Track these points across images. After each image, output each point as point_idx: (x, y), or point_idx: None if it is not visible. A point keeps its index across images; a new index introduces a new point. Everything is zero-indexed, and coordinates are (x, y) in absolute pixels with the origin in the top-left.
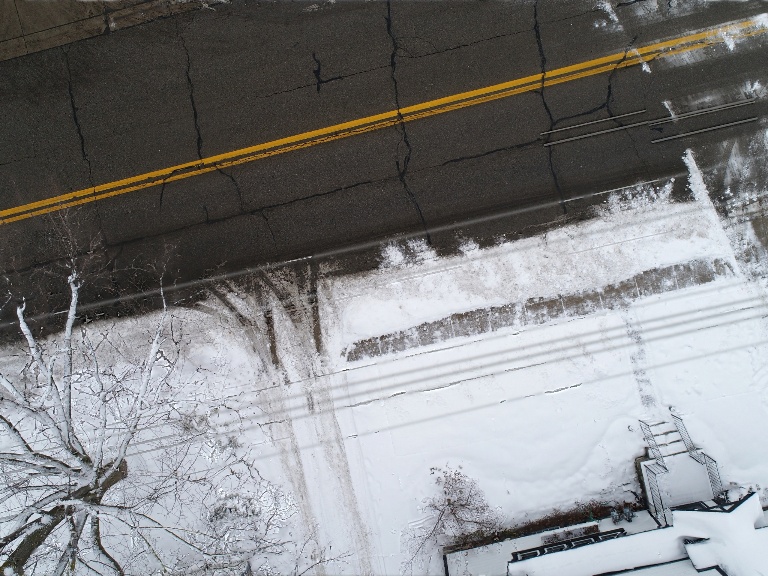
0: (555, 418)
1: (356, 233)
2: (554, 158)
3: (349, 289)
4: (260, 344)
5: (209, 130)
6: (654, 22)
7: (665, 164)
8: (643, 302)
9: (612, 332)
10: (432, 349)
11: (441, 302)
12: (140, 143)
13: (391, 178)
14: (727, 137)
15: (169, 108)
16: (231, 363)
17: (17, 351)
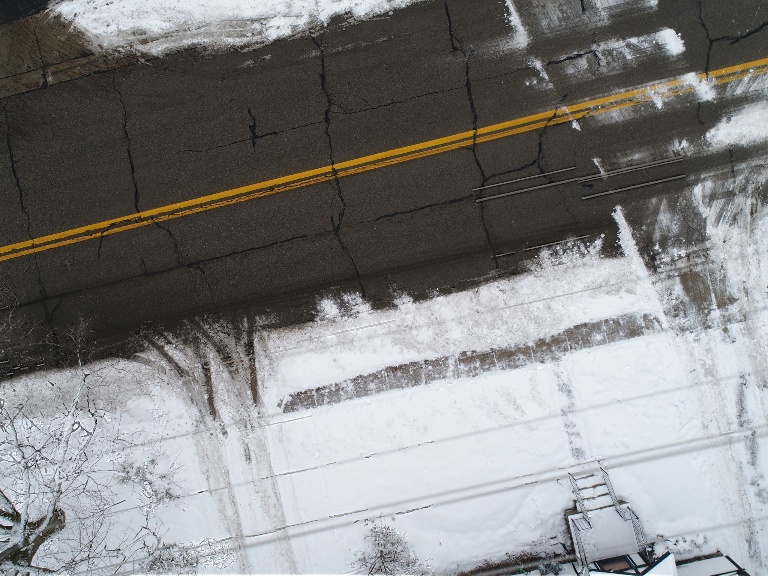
0: (486, 470)
1: (292, 286)
2: (486, 214)
3: (285, 342)
4: (198, 395)
5: (146, 184)
6: (584, 80)
7: (595, 220)
8: (573, 356)
9: (542, 386)
10: (366, 401)
11: (374, 356)
12: (78, 196)
13: (326, 232)
14: (656, 194)
15: (106, 162)
16: (169, 414)
17: None
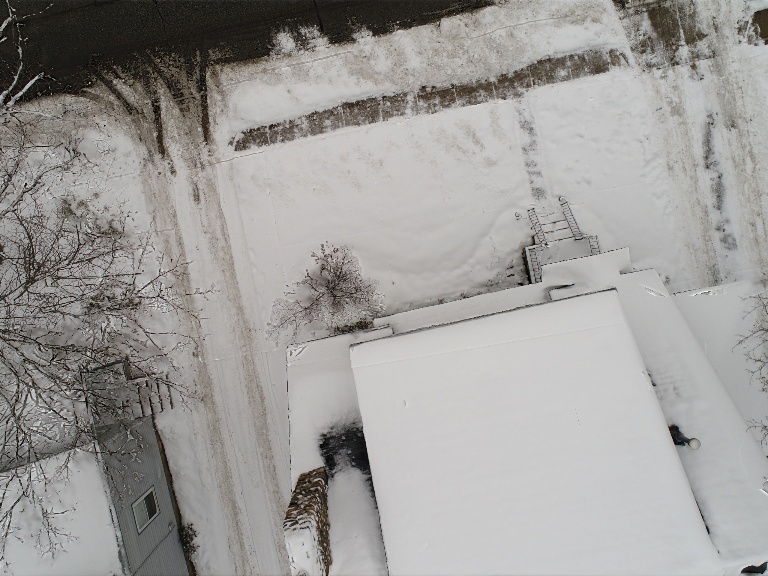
0: (443, 208)
1: (247, 18)
2: None
3: (238, 74)
4: (146, 133)
5: None
6: None
7: None
8: (536, 91)
9: (503, 120)
10: (321, 137)
11: (330, 87)
12: None
13: None
14: None
15: None
16: (116, 151)
17: None
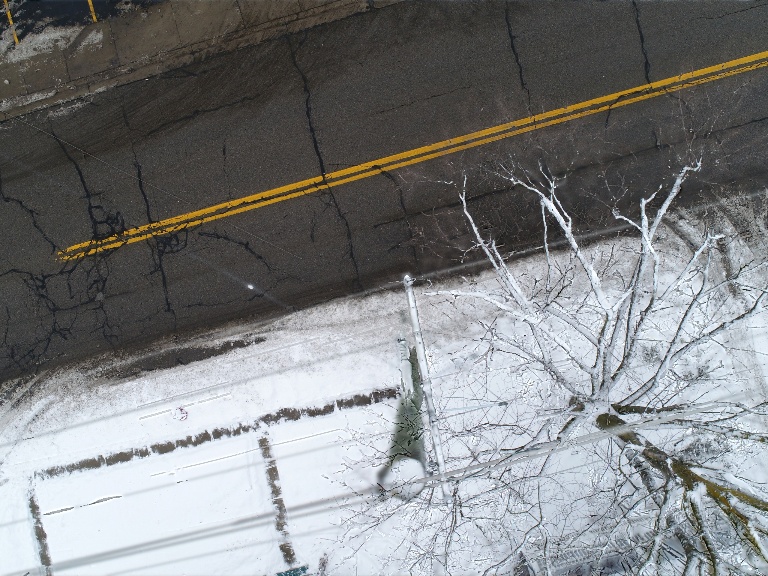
0: None
1: None
2: None
3: None
4: (715, 272)
5: (657, 54)
6: None
7: None
8: None
9: None
10: None
11: None
12: (583, 69)
13: None
14: None
15: (613, 33)
16: None
17: None
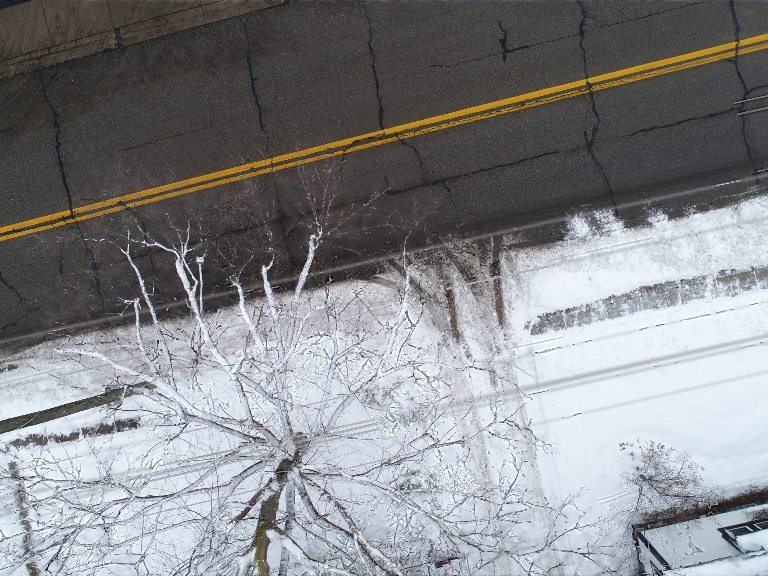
0: (750, 392)
1: (541, 204)
2: (747, 128)
3: (535, 261)
4: (440, 317)
5: (391, 100)
6: None
7: None
8: None
9: None
10: (621, 322)
11: (632, 274)
12: (320, 113)
13: (578, 148)
14: None
15: (350, 78)
16: (411, 337)
17: (188, 325)
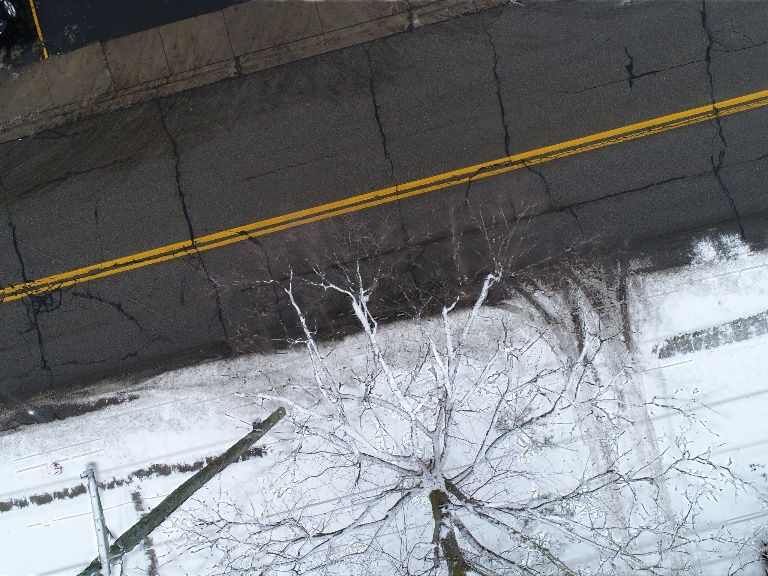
0: None
1: (668, 229)
2: None
3: (663, 285)
4: (567, 342)
5: (517, 127)
6: None
7: None
8: None
9: None
10: (749, 345)
11: (761, 297)
12: (445, 141)
13: (705, 173)
14: None
15: (475, 105)
16: (538, 362)
17: None
